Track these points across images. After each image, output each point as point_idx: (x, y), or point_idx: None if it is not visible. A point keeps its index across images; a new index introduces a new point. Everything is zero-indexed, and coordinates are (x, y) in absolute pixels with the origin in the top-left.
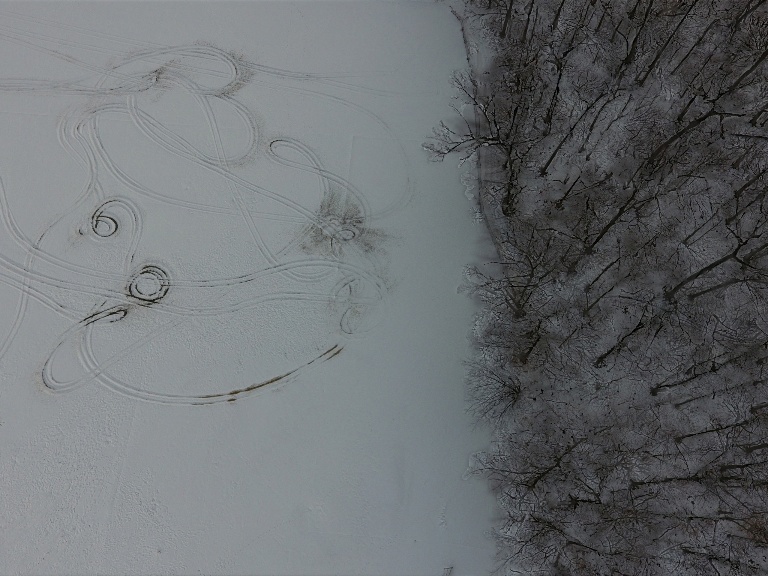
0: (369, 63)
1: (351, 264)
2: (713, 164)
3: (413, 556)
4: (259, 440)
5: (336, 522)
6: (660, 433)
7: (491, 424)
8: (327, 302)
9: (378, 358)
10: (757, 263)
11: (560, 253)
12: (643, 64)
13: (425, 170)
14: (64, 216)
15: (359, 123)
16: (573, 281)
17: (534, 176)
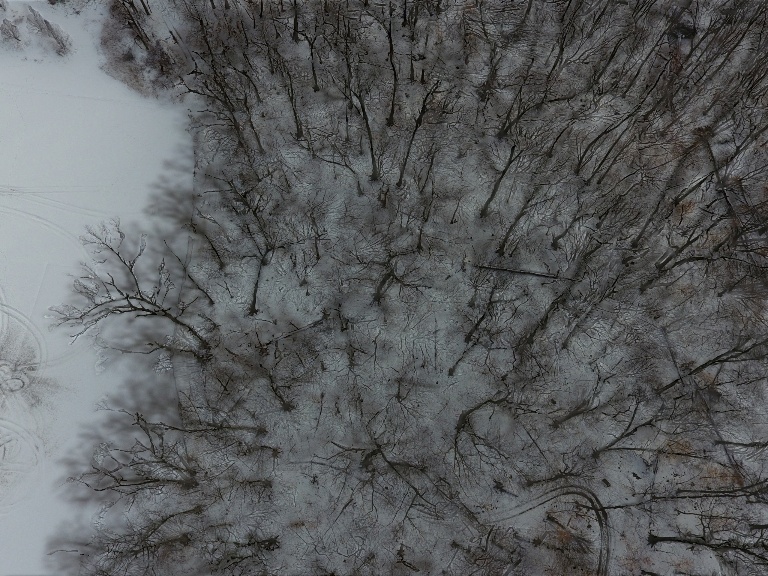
0: (84, 176)
1: (11, 421)
2: (446, 302)
3: None
4: None
5: None
6: None
7: None
8: None
9: (17, 538)
10: (474, 423)
11: (252, 409)
12: (390, 181)
13: None
14: None
15: (57, 248)
16: (261, 443)
17: (242, 314)
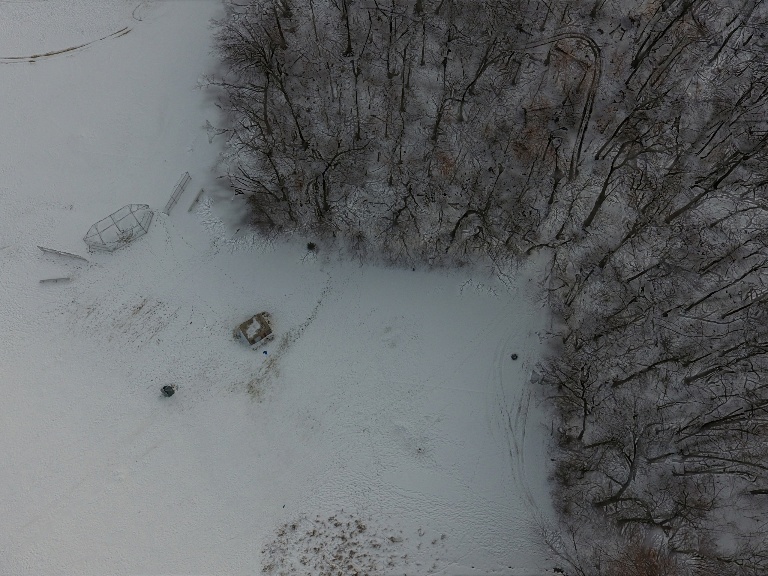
0: None
1: None
2: None
3: (162, 171)
4: (50, 89)
5: (103, 146)
6: None
7: (237, 76)
8: None
9: (160, 38)
10: None
11: None
12: None
13: None
14: None
15: None
16: None
17: None
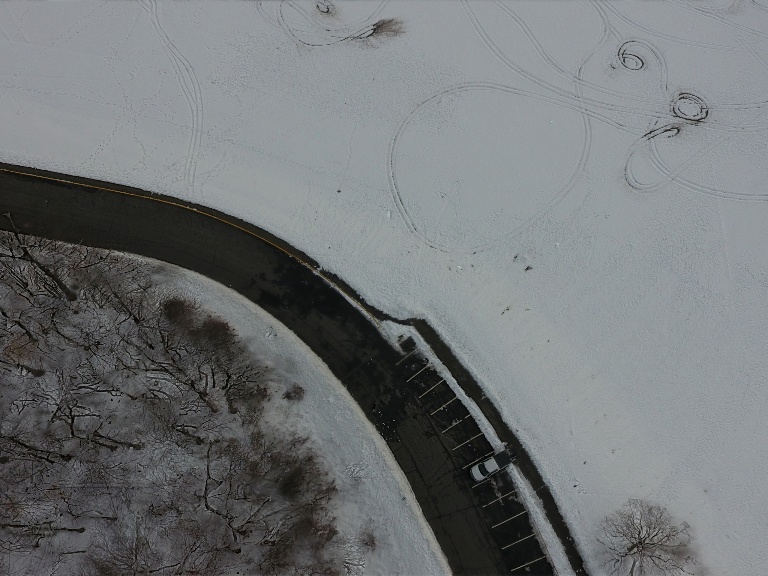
0: None
1: None
2: None
3: None
4: None
5: None
6: None
7: None
8: None
9: None
10: None
11: None
12: None
13: None
14: (593, 53)
15: None
16: None
17: None
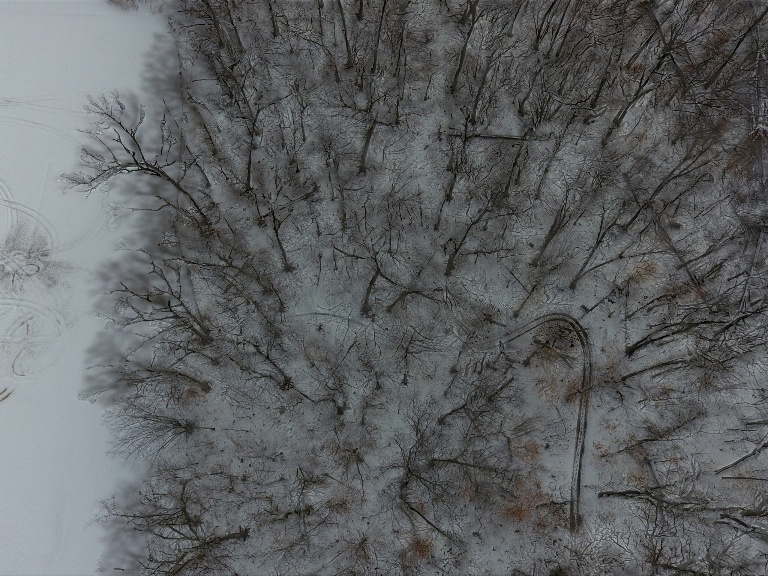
0: (75, 83)
1: (31, 301)
2: (427, 168)
3: None
4: None
5: None
6: (340, 454)
7: (148, 462)
8: (1, 344)
9: (49, 399)
10: (461, 268)
11: None
12: (365, 67)
13: (121, 195)
14: None
15: (57, 149)
16: (268, 301)
17: (239, 193)
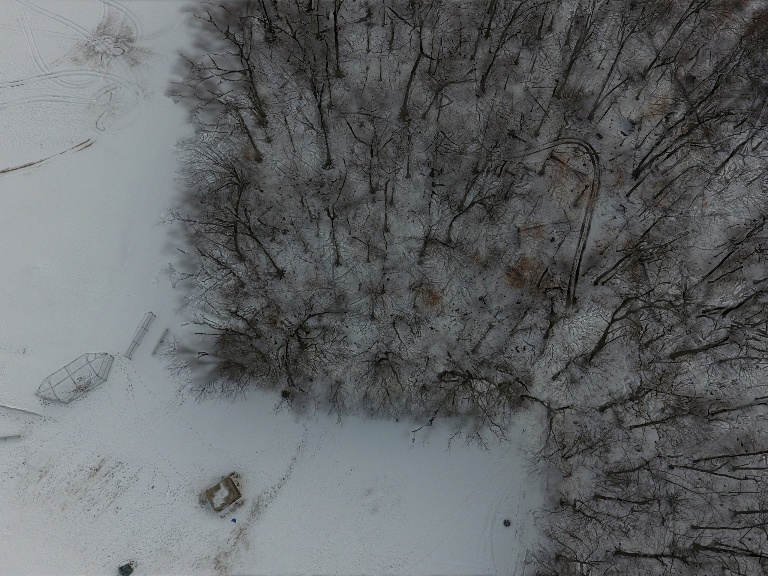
0: None
1: (116, 75)
2: (469, 8)
3: (124, 307)
4: (4, 212)
5: (60, 278)
6: (370, 222)
7: (206, 200)
8: (87, 105)
9: (124, 151)
10: (492, 91)
11: (310, 75)
12: None
13: None
14: None
15: None
16: None
17: (301, 11)
